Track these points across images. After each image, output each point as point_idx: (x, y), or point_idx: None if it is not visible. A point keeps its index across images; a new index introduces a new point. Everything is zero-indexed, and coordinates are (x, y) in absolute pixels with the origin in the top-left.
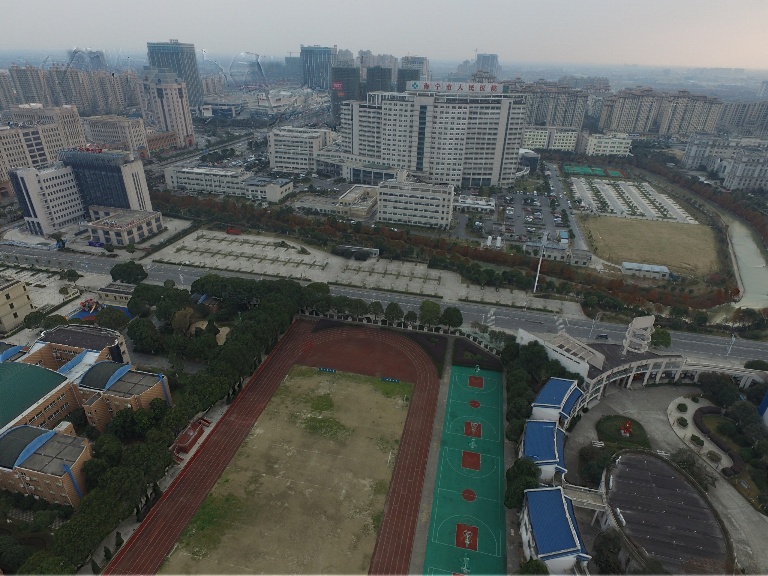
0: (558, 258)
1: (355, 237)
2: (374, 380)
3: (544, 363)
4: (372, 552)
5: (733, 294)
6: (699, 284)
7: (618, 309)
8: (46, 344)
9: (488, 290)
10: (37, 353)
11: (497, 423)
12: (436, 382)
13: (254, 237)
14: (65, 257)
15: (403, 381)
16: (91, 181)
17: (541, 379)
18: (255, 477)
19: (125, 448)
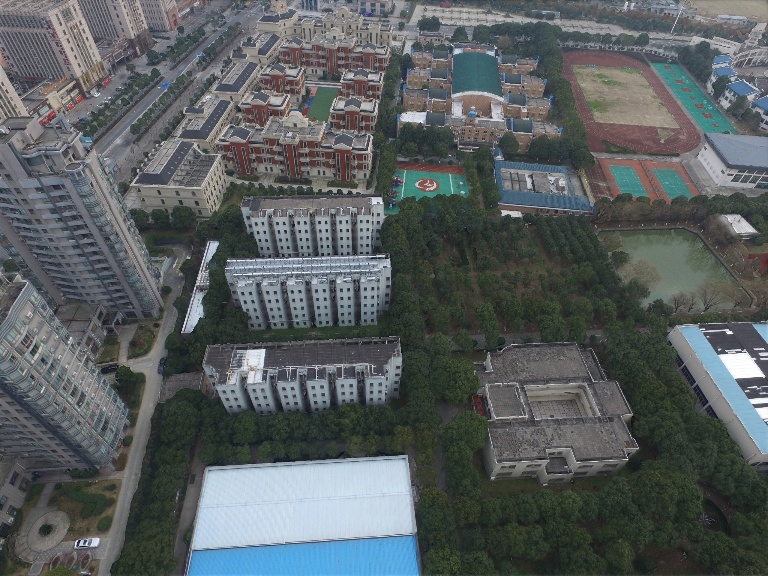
0: (675, 15)
1: (538, 5)
2: (618, 68)
3: (710, 51)
4: (668, 110)
5: None
6: None
7: None
8: (462, 49)
9: None
10: None
11: (689, 79)
12: (649, 68)
13: (462, 9)
14: None
15: (633, 68)
16: None
17: (710, 58)
18: (600, 96)
19: None
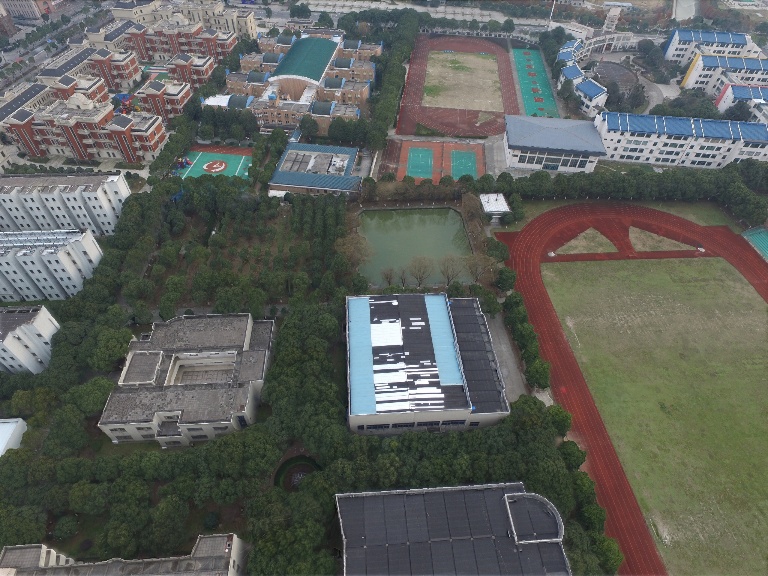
0: (563, 2)
1: None
2: (475, 54)
3: (564, 36)
4: (501, 95)
5: (668, 17)
6: (649, 13)
7: (600, 25)
8: (309, 34)
9: (522, 20)
10: None
11: (541, 65)
12: (507, 54)
13: None
14: None
15: (490, 54)
16: None
17: (562, 43)
18: (440, 81)
19: None
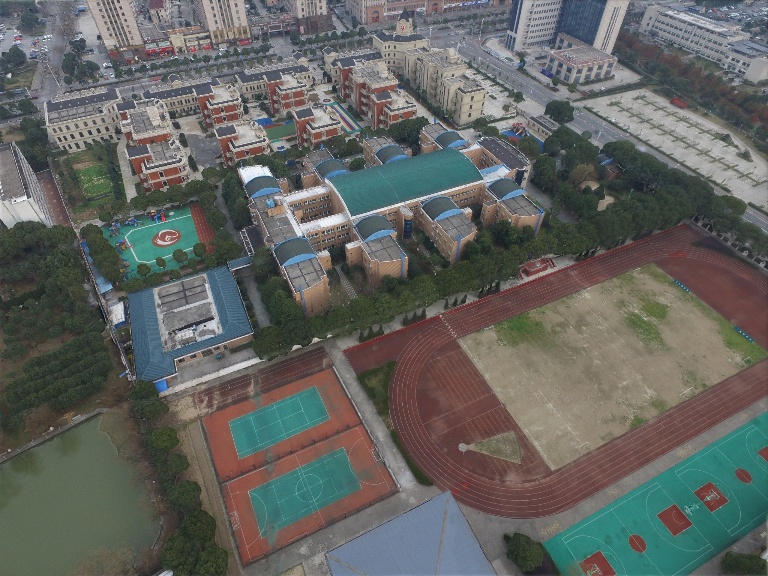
0: None
1: None
2: (725, 323)
3: None
4: (617, 436)
5: None
6: None
7: None
8: (481, 147)
9: None
10: (473, 151)
11: None
12: None
13: (698, 117)
14: (519, 77)
15: (758, 344)
16: (574, 7)
17: None
18: (564, 324)
19: (492, 248)
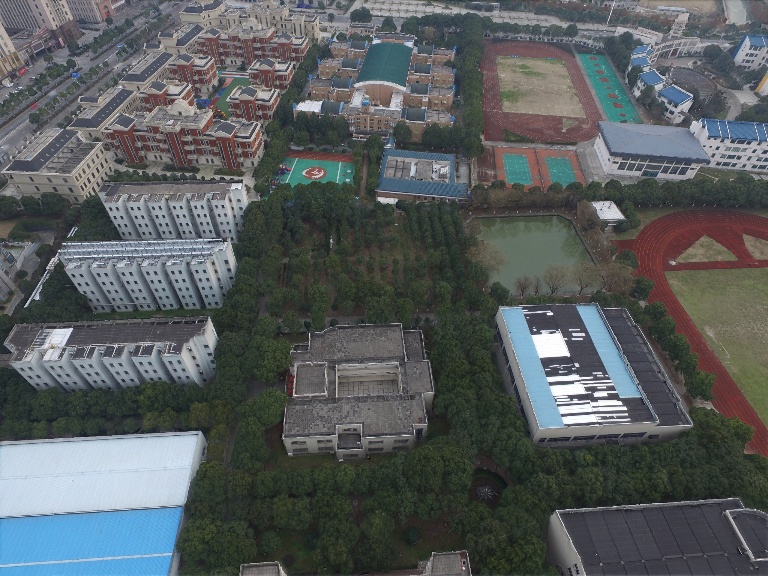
0: (616, 7)
1: None
2: (542, 59)
3: (632, 41)
4: (579, 100)
5: (723, 22)
6: (703, 18)
7: (658, 29)
8: (381, 39)
9: (579, 24)
10: None
11: (610, 70)
12: (573, 59)
13: (403, 0)
14: None
15: (557, 59)
16: None
17: (632, 48)
18: (515, 86)
19: None
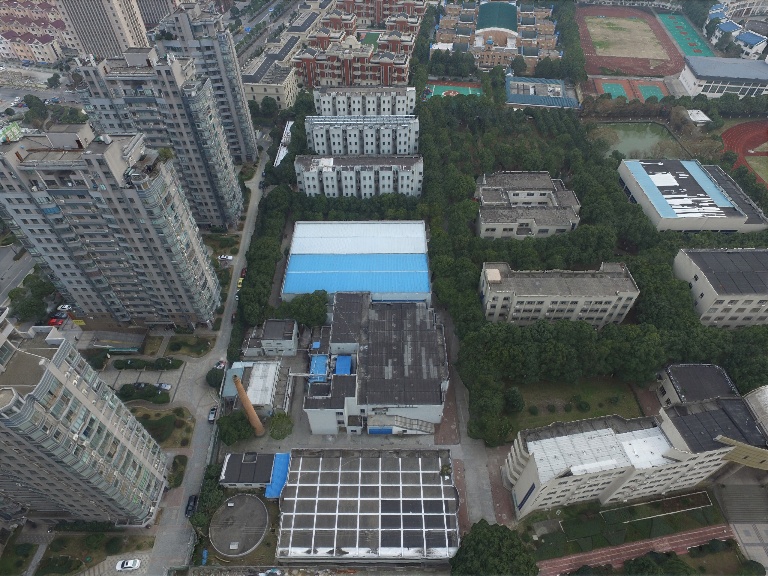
0: None
1: None
2: (626, 18)
3: (710, 1)
4: (663, 47)
5: None
6: None
7: None
8: (488, 1)
9: None
10: None
11: (689, 26)
12: (654, 18)
13: None
14: None
15: (639, 18)
16: None
17: (709, 7)
18: (605, 38)
19: None
